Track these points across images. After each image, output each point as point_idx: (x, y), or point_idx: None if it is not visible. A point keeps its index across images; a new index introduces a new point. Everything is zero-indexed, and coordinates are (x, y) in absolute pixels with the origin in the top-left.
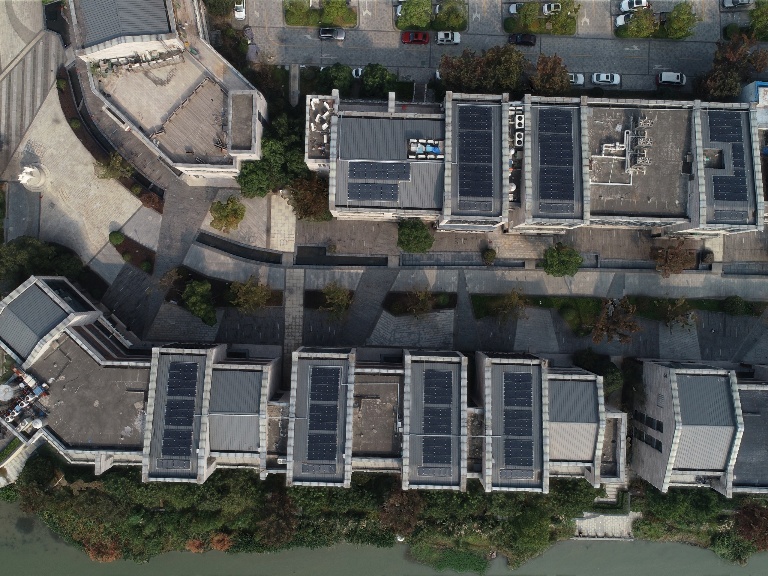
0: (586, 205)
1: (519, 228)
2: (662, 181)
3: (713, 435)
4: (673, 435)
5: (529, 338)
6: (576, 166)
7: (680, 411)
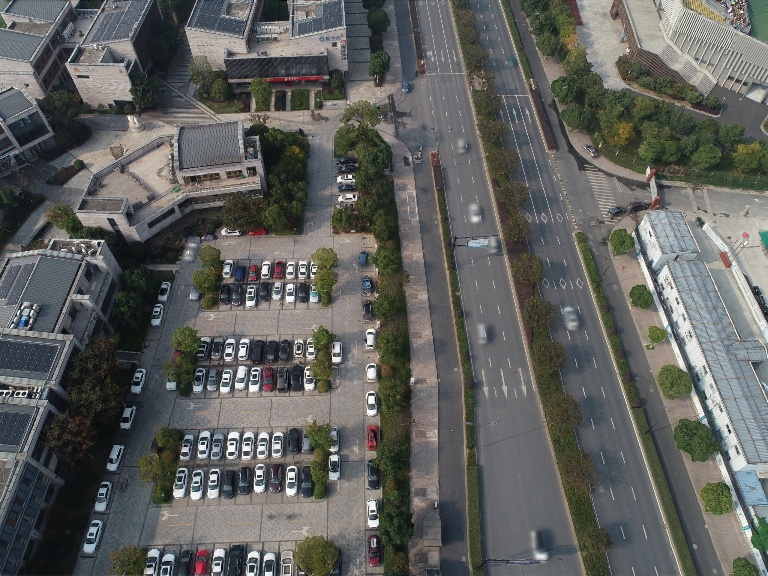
0: None
1: None
2: None
3: None
4: None
5: None
6: None
7: None
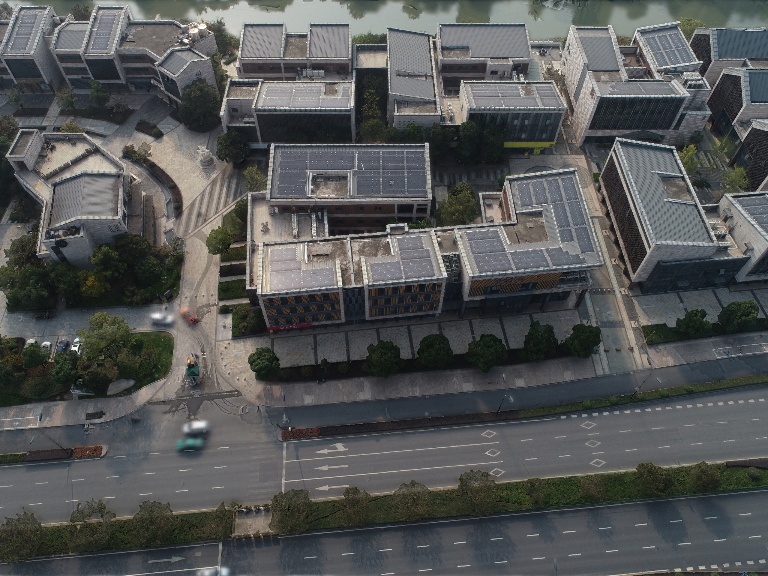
0: None
1: None
2: None
3: None
4: None
5: None
6: None
7: None
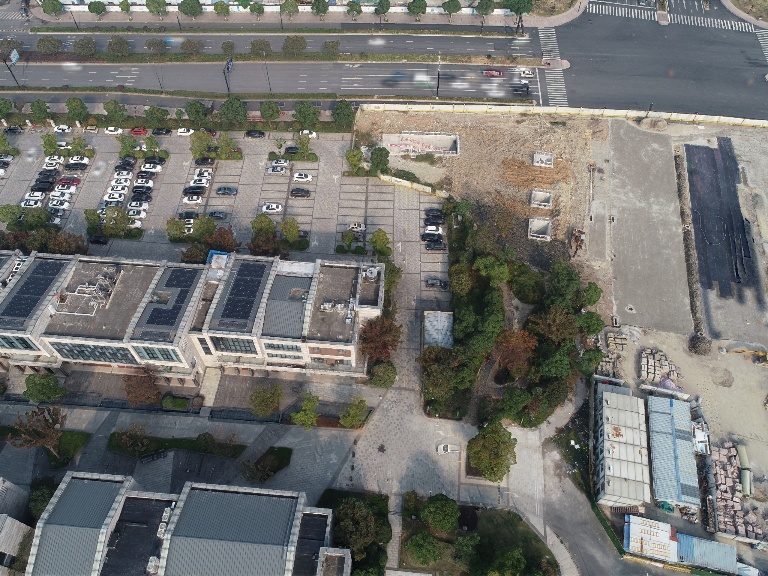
0: (33, 320)
1: (17, 359)
2: (120, 314)
3: (79, 539)
4: (35, 535)
5: (6, 468)
6: (45, 296)
7: (54, 511)
